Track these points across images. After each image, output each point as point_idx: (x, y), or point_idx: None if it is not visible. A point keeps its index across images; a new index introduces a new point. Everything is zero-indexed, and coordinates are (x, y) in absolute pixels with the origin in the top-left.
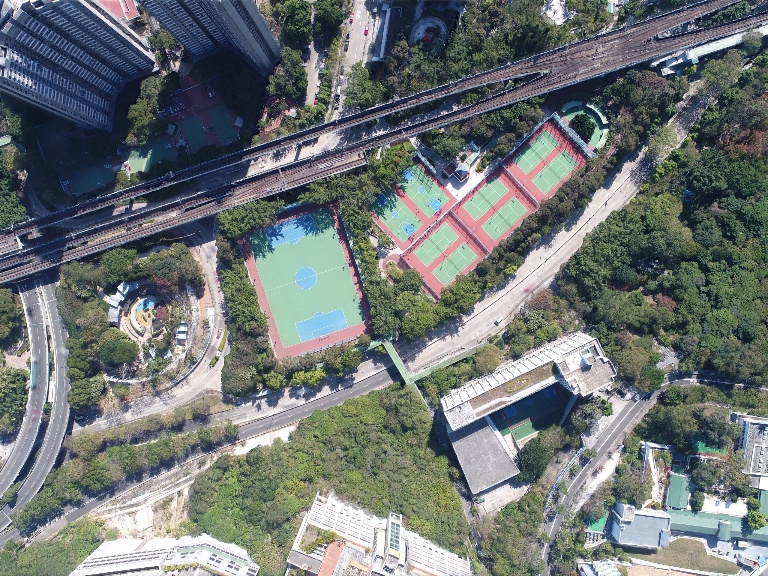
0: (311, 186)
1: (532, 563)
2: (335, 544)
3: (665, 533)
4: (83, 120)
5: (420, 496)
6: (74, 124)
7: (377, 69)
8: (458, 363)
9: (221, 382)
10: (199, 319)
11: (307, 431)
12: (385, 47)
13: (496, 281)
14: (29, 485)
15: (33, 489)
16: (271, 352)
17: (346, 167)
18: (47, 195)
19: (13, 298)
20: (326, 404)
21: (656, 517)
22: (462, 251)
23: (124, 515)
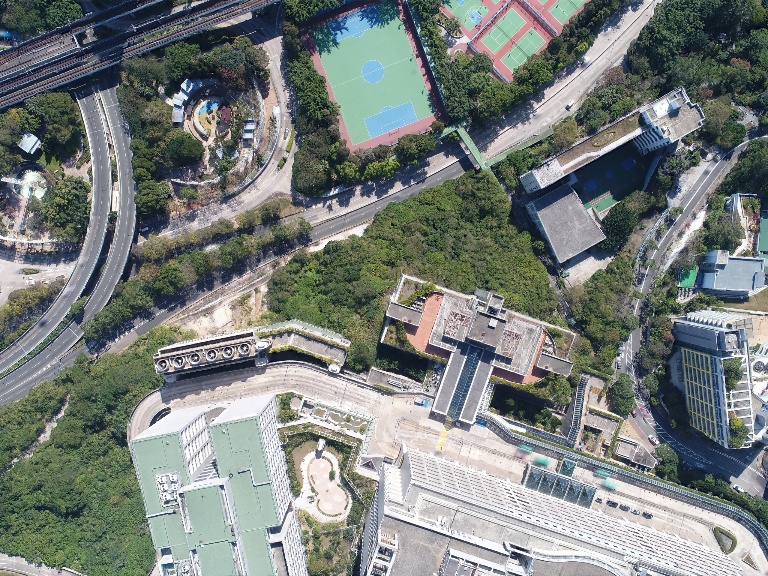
0: None
1: (627, 317)
2: (433, 298)
3: (760, 274)
4: None
5: (506, 270)
6: None
7: None
8: (532, 147)
9: (290, 184)
10: (265, 120)
11: (384, 221)
12: None
13: (567, 60)
14: (96, 299)
15: (101, 303)
16: (344, 141)
17: None
18: None
19: None
20: (399, 200)
21: (749, 260)
22: (530, 36)
23: (200, 317)
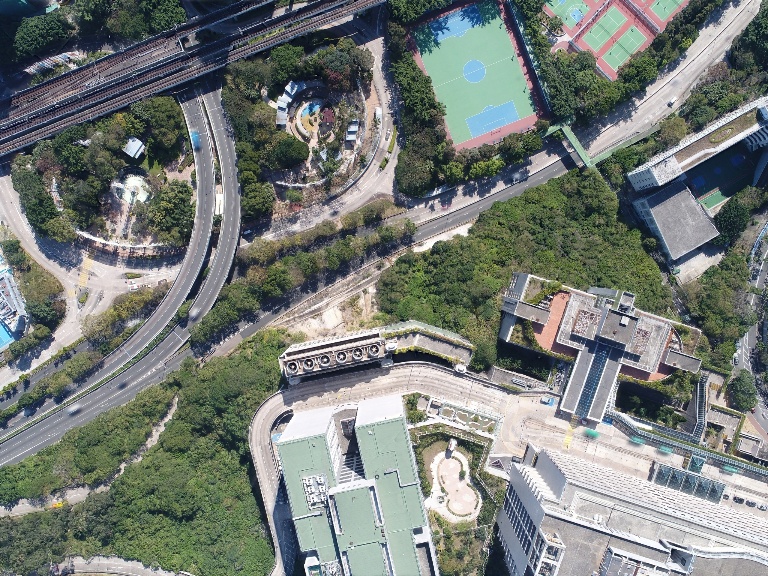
0: None
1: (747, 313)
2: (559, 297)
3: None
4: None
5: (618, 268)
6: None
7: None
8: (636, 144)
9: (392, 184)
10: None
11: (491, 220)
12: None
13: (672, 57)
14: (201, 302)
15: (205, 306)
16: (451, 141)
17: None
18: None
19: None
20: (501, 199)
21: None
22: (631, 34)
23: (308, 319)
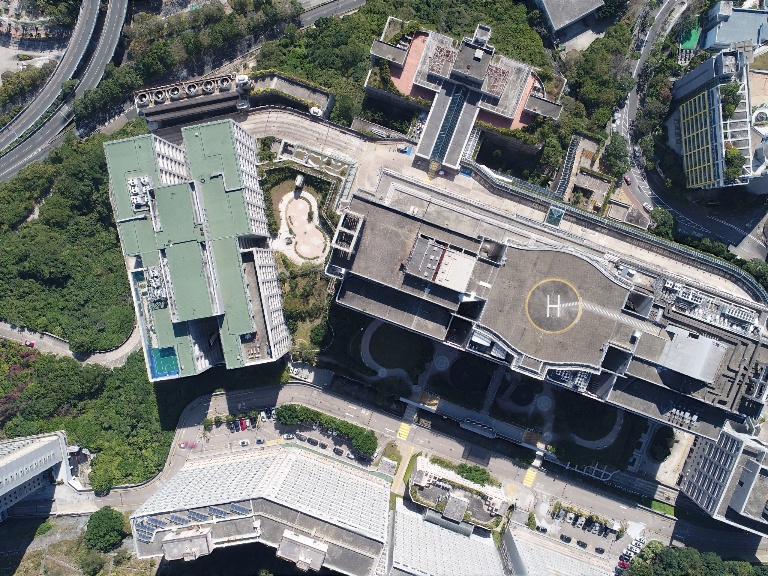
0: None
1: (623, 75)
2: (419, 40)
3: (765, 25)
4: None
5: (499, 40)
6: None
7: None
8: None
9: None
10: None
11: None
12: None
13: None
14: (87, 82)
15: (91, 85)
16: None
17: None
18: None
19: None
20: None
21: (755, 12)
22: None
23: None
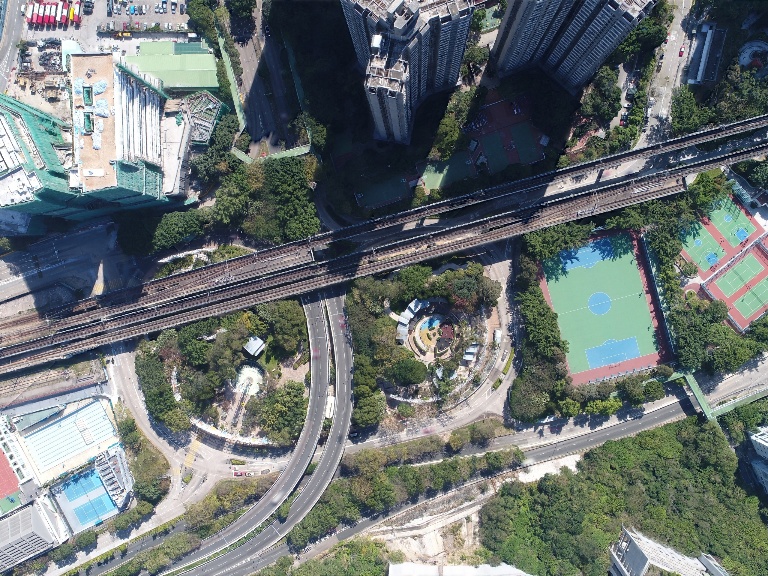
0: (628, 211)
1: None
2: None
3: None
4: (398, 133)
5: (733, 537)
6: (371, 136)
7: (696, 92)
8: (761, 399)
9: (504, 406)
10: None
11: (603, 462)
12: (705, 70)
13: None
14: (302, 501)
15: (306, 505)
16: (571, 379)
17: (663, 193)
18: (347, 208)
19: None
20: (613, 434)
21: None
22: (767, 283)
23: (407, 538)
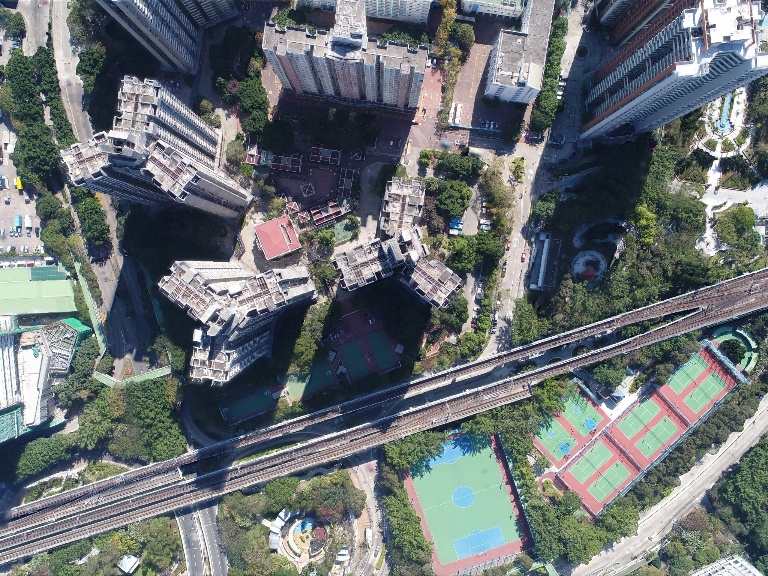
0: (478, 419)
1: None
2: None
3: None
4: None
5: None
6: None
7: (537, 299)
8: None
9: None
10: None
11: None
12: (544, 277)
13: (653, 502)
14: None
15: None
16: None
17: (511, 398)
18: (211, 428)
19: (170, 524)
20: None
21: None
22: (616, 469)
23: None
